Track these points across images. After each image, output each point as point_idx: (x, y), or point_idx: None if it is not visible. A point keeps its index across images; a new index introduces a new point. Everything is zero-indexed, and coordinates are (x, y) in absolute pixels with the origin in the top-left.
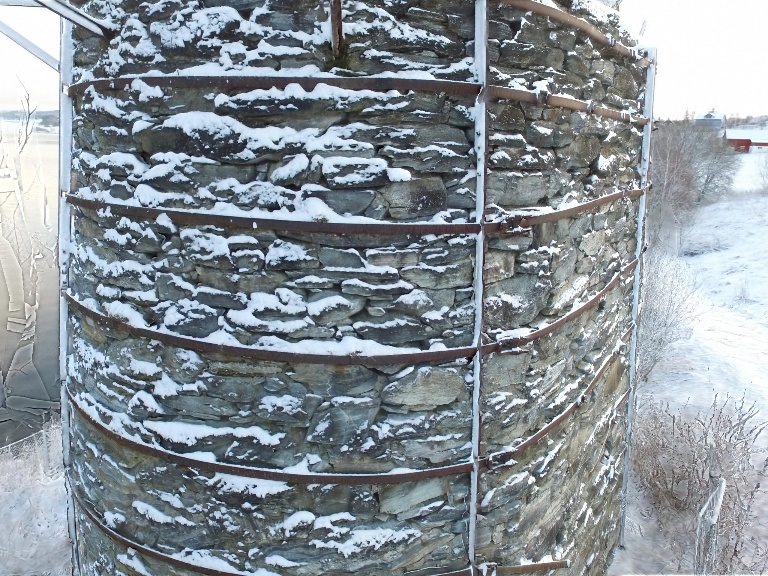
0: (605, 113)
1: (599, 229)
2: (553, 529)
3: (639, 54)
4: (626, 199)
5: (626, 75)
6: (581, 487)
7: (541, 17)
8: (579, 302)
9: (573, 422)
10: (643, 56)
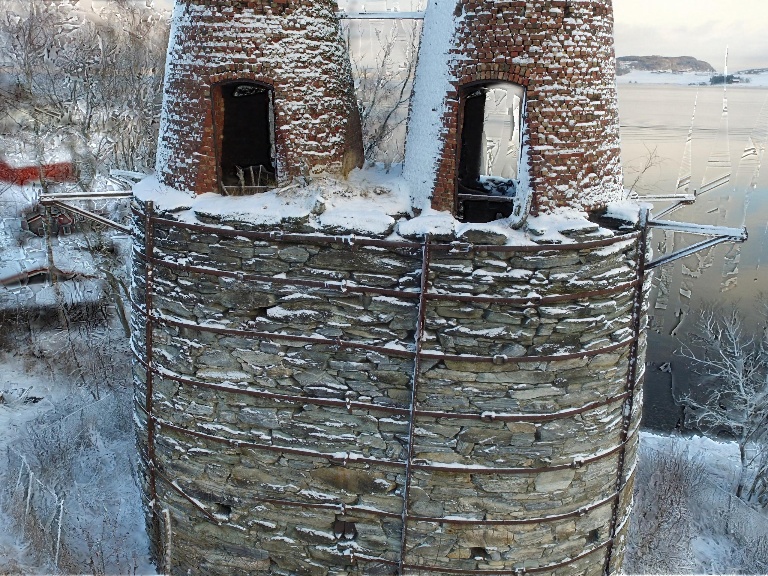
0: (279, 281)
1: (272, 353)
2: (209, 494)
3: (407, 236)
4: (364, 350)
5: (340, 255)
6: (261, 507)
7: (182, 228)
8: (231, 384)
9: (233, 452)
10: (423, 237)
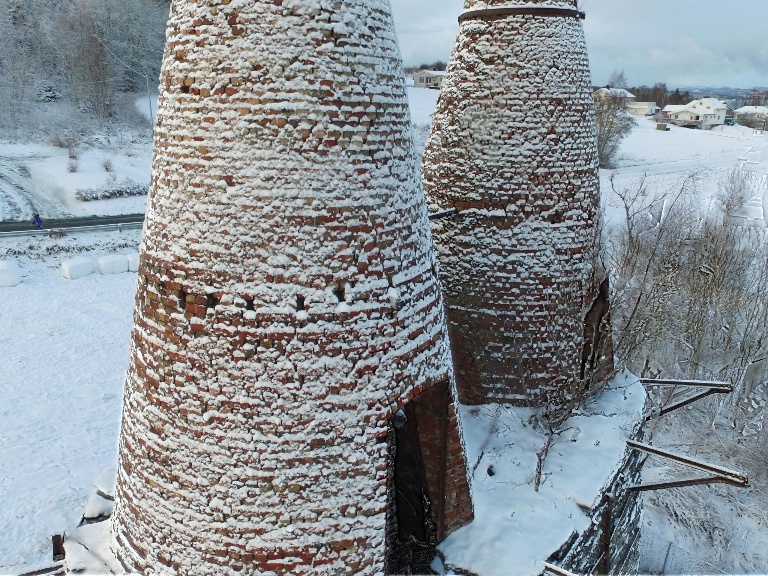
0: None
1: None
2: None
3: None
4: None
5: None
6: None
7: None
8: None
9: None
10: None
